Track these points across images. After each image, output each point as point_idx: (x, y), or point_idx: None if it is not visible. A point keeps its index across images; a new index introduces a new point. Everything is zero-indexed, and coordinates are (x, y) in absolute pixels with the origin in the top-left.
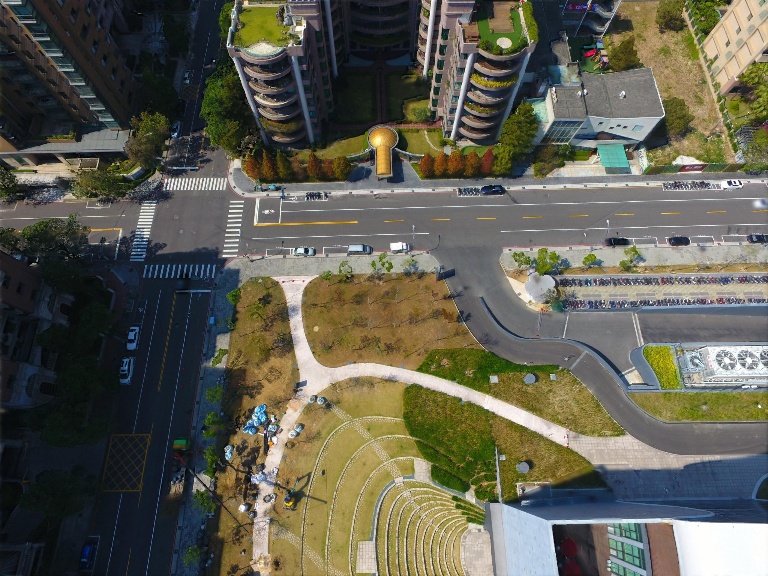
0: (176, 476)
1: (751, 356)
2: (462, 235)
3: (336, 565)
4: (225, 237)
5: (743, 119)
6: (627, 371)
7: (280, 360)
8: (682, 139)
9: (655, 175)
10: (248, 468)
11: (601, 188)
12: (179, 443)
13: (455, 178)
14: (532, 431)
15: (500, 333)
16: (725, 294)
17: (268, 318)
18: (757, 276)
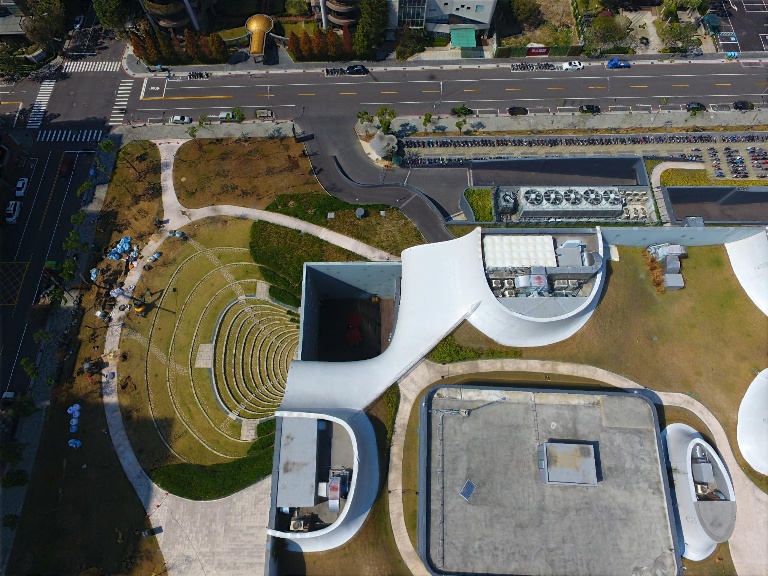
0: (46, 291)
1: (556, 193)
2: (324, 107)
3: (177, 360)
4: (113, 109)
5: (591, 12)
6: (455, 214)
7: (148, 203)
8: (535, 29)
9: (505, 58)
10: (109, 286)
11: (455, 69)
12: (49, 263)
13: (324, 61)
14: (358, 255)
15: (345, 183)
16: (552, 154)
17: (142, 171)
18: (583, 139)
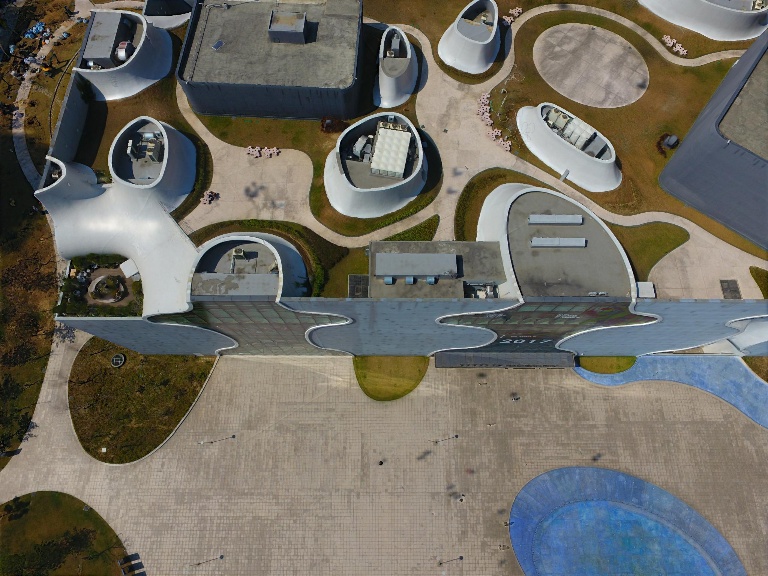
0: None
1: None
2: None
3: None
4: None
5: None
6: None
7: None
8: None
9: None
10: (24, 57)
11: None
12: None
13: None
14: None
15: None
16: None
17: None
18: None
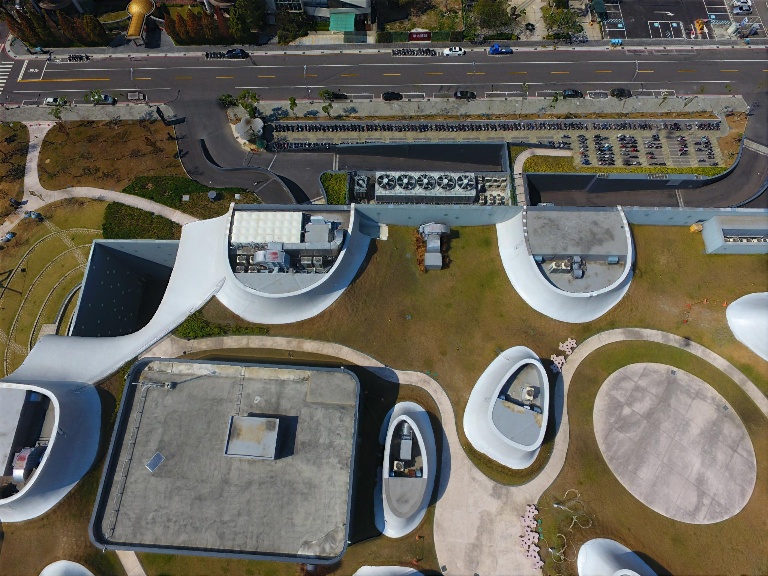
0: None
1: (409, 178)
2: (199, 90)
3: (18, 340)
4: None
5: None
6: (315, 199)
7: (9, 184)
8: (422, 15)
9: (387, 44)
10: None
11: (336, 54)
12: None
13: (206, 45)
14: None
15: (208, 166)
16: (421, 139)
17: (9, 153)
18: (453, 125)
